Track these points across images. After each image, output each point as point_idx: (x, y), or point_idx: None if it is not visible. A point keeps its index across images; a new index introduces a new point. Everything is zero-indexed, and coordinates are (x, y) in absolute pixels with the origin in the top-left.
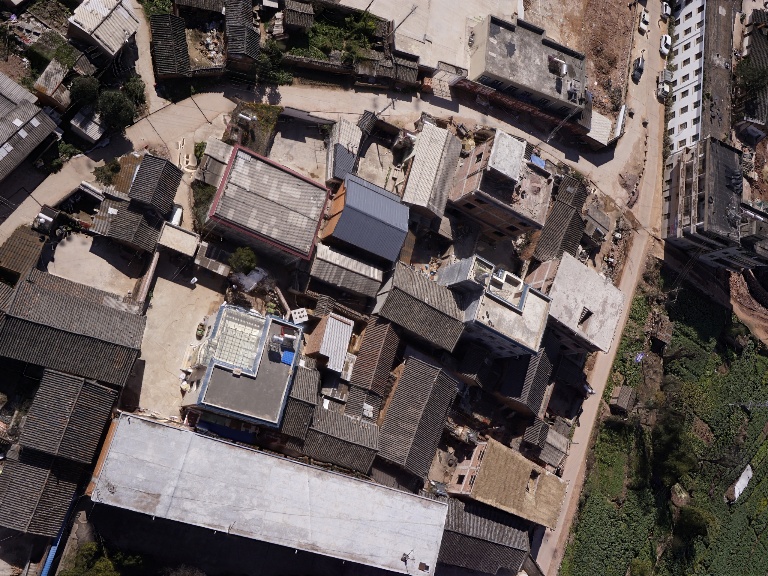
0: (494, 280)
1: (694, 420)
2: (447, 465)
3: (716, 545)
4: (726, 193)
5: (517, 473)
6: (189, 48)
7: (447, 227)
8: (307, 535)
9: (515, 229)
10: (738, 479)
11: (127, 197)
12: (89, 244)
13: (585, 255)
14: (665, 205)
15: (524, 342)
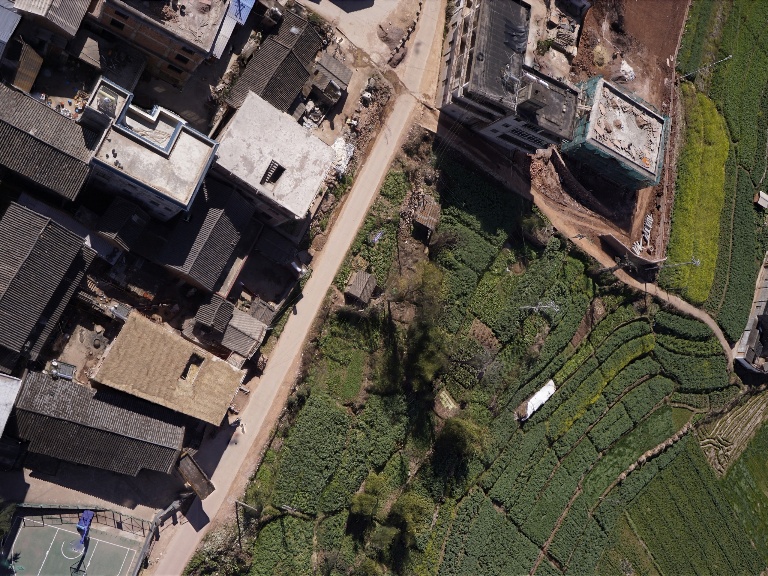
0: (143, 117)
1: (473, 323)
2: (92, 346)
3: (499, 465)
4: (504, 51)
5: (169, 356)
6: None
7: (94, 52)
8: None
9: (186, 60)
10: (534, 394)
11: None
12: None
13: (317, 113)
14: (445, 70)
15: (169, 192)
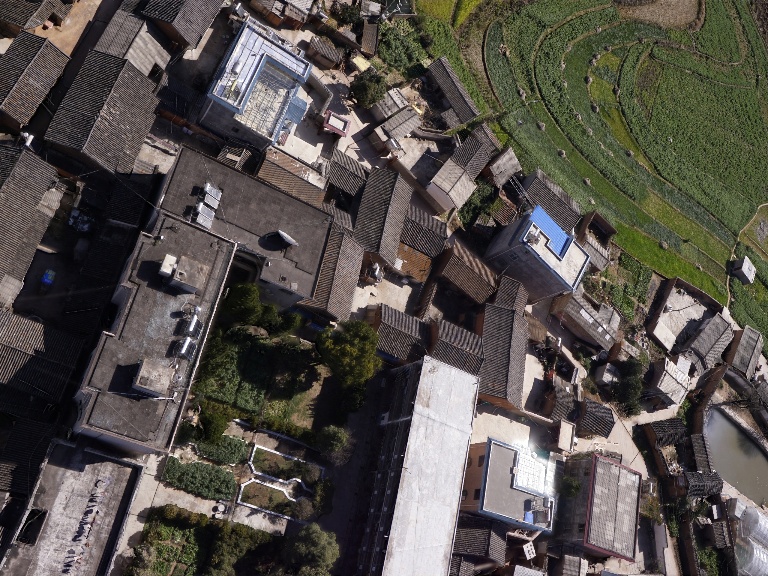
0: None
1: None
2: None
3: None
4: None
5: None
6: (665, 450)
7: None
8: (399, 547)
9: None
10: None
11: (580, 399)
12: (539, 378)
13: None
14: None
15: None
